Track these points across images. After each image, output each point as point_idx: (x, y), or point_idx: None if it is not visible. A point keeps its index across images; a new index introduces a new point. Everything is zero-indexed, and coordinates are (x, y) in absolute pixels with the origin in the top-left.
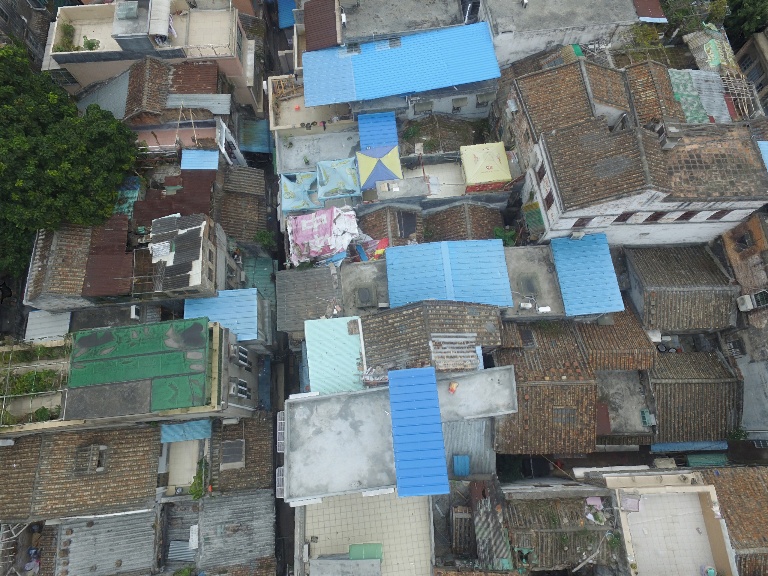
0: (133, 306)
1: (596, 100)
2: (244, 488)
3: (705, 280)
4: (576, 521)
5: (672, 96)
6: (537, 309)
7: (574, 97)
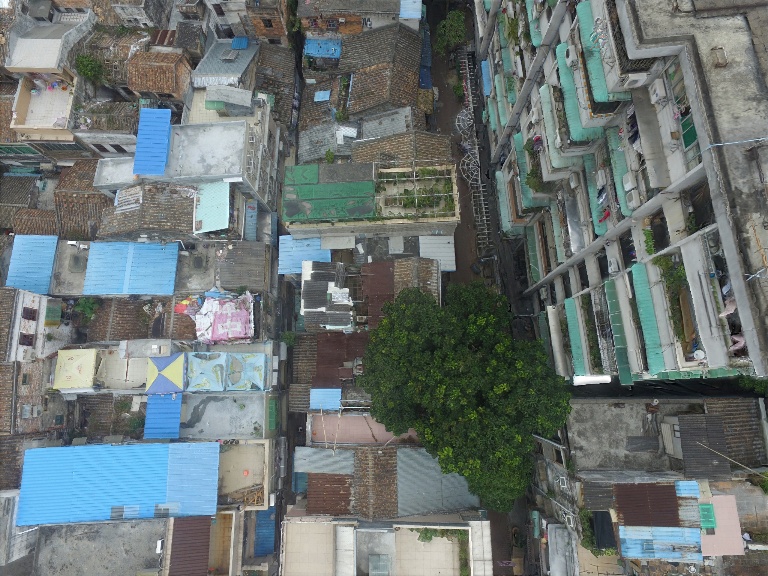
0: None
1: None
2: (310, 162)
3: None
4: (98, 119)
5: None
6: (78, 245)
7: None
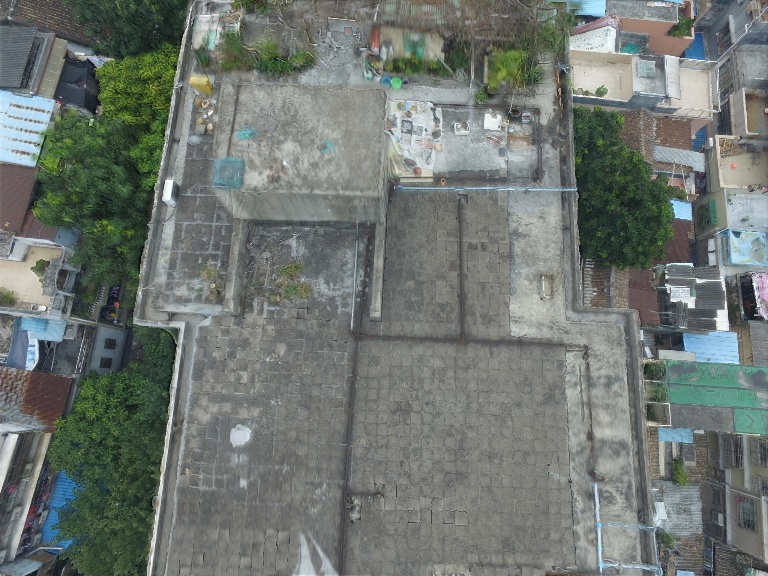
0: None
1: None
2: (695, 481)
3: None
4: None
5: None
6: None
7: None
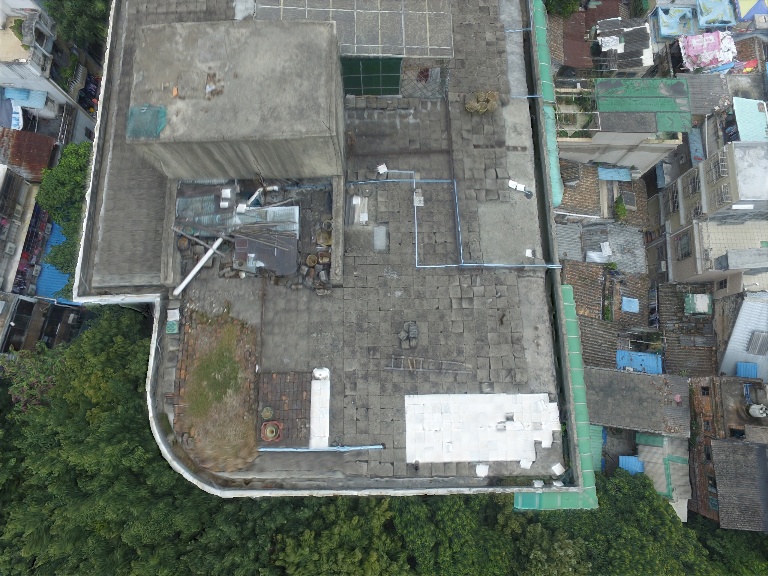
0: (579, 83)
1: None
2: (636, 224)
3: None
4: None
5: None
6: None
7: None
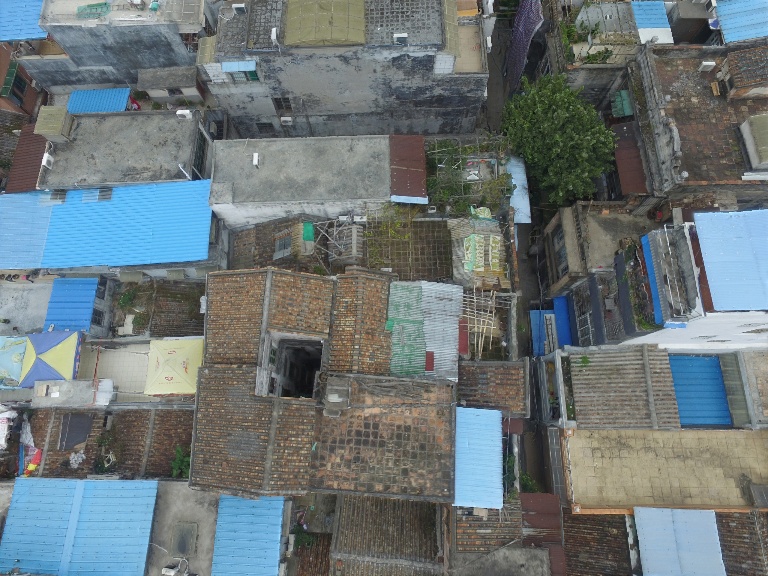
0: None
1: (272, 330)
2: None
3: (410, 548)
4: None
5: (380, 325)
6: (184, 575)
7: (250, 320)
